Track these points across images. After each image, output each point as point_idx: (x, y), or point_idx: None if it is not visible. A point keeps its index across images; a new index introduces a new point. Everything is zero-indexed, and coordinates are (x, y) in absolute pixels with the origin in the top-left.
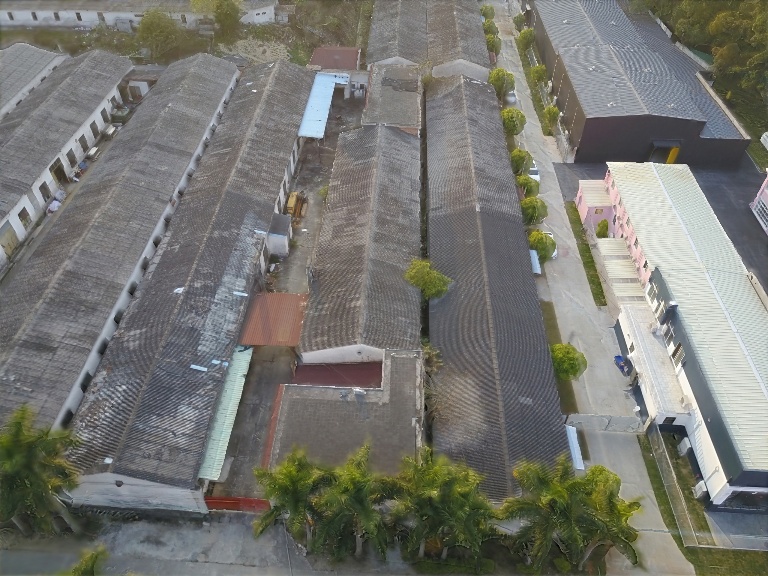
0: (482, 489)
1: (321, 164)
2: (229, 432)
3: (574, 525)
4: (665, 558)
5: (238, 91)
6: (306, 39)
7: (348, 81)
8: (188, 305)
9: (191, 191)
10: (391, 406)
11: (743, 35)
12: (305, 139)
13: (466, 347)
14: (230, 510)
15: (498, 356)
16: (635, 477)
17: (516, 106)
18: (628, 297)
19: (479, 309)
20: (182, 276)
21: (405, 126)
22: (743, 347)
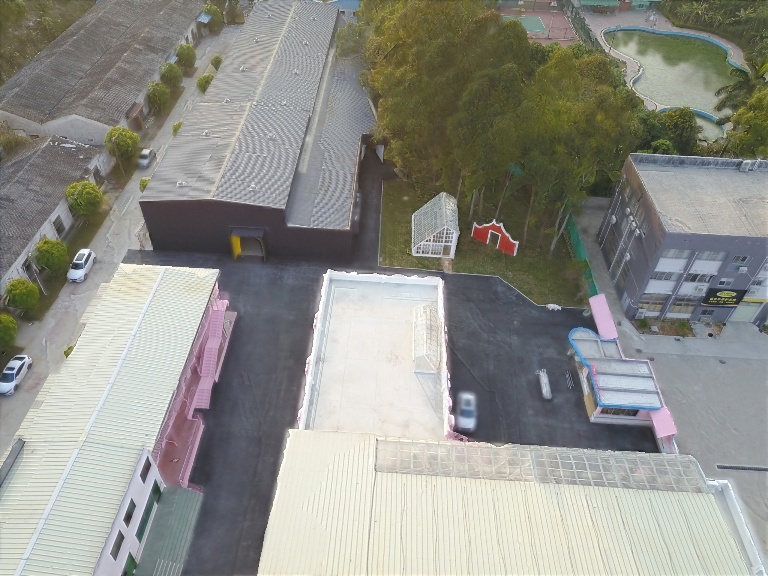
0: None
1: None
2: None
3: None
4: None
5: None
6: None
7: None
8: None
9: None
10: None
11: None
12: None
13: None
14: None
15: None
16: None
17: (147, 170)
18: None
19: None
20: None
21: None
22: None
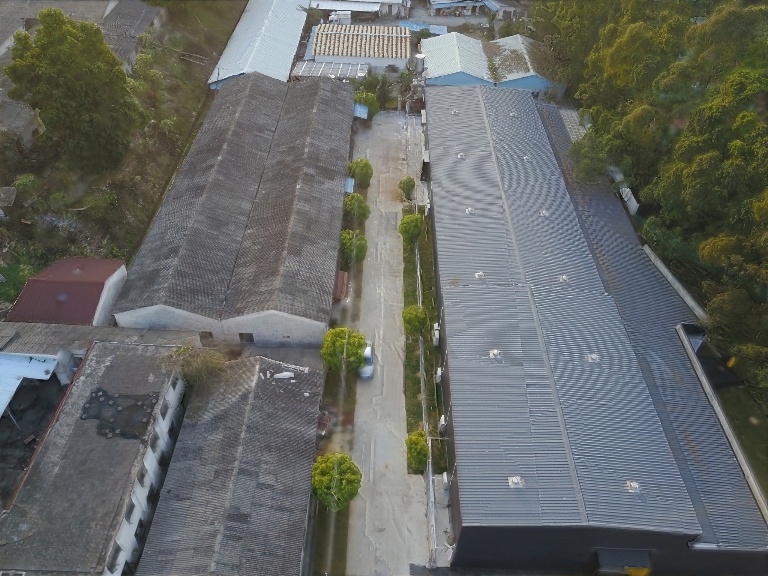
0: None
1: None
2: None
3: None
4: None
5: None
6: (38, 242)
7: (51, 370)
8: None
9: None
10: None
11: (760, 295)
12: None
13: None
14: None
15: None
16: None
17: (373, 383)
18: None
19: None
20: None
21: None
22: None
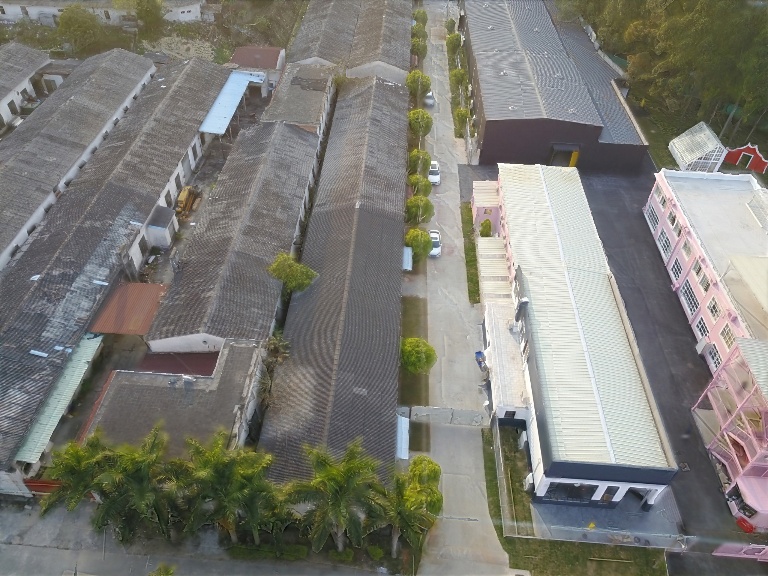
0: (294, 476)
1: (225, 160)
2: (58, 417)
3: (342, 507)
4: (482, 548)
5: (148, 86)
6: (232, 38)
7: (263, 80)
8: (41, 292)
9: (76, 182)
10: (217, 393)
11: (651, 44)
12: (214, 135)
13: (314, 339)
14: (39, 492)
15: (341, 348)
16: (471, 469)
17: (434, 109)
18: (495, 294)
19: (335, 302)
20: (42, 264)
21: (303, 124)
22: (584, 343)
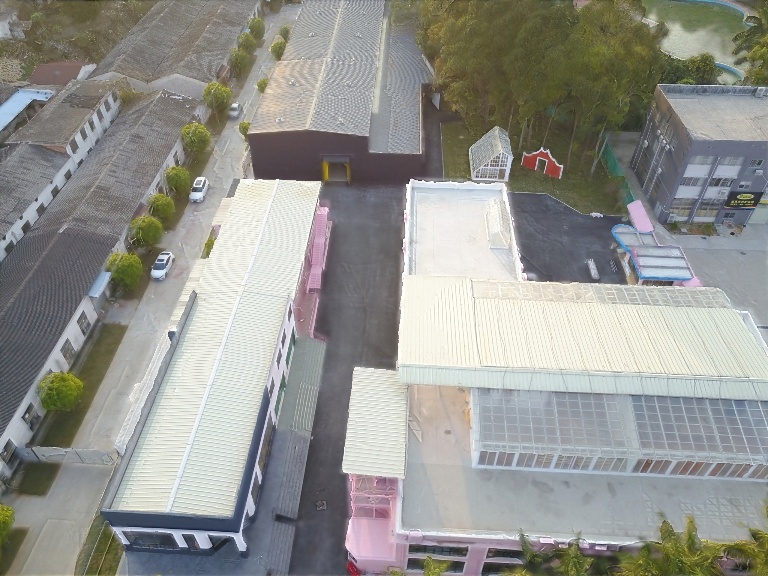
0: None
1: None
2: None
3: None
4: None
5: None
6: (45, 54)
7: (49, 97)
8: None
9: None
10: None
11: None
12: None
13: None
14: None
15: None
16: (81, 514)
17: (237, 121)
18: None
19: None
20: None
21: (49, 144)
22: (212, 376)
